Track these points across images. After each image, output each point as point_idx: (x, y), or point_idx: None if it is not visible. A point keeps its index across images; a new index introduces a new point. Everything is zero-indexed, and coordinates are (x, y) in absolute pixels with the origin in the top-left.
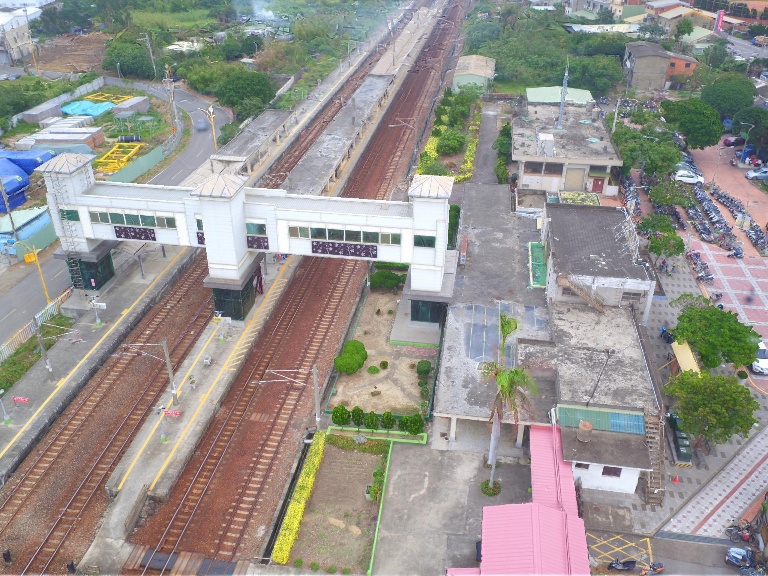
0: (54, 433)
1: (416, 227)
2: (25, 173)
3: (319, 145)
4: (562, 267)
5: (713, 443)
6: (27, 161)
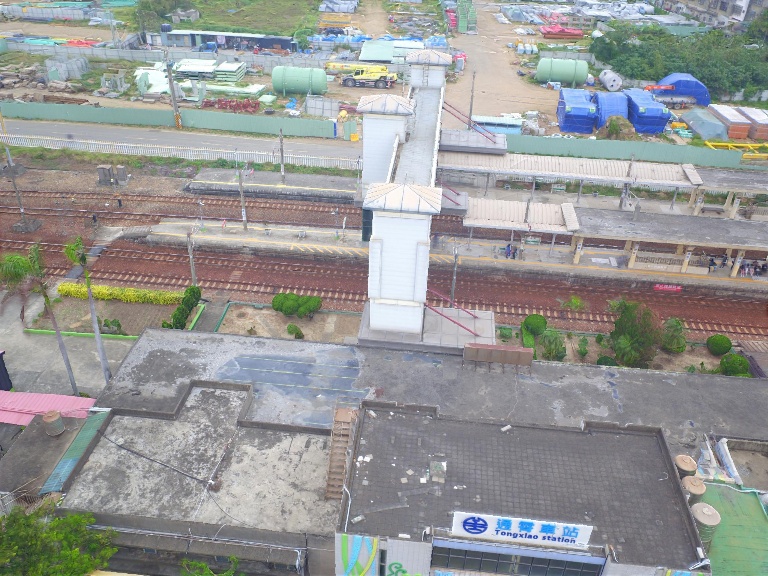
0: (235, 199)
1: None
2: (627, 116)
3: None
4: (400, 422)
5: None
6: (636, 107)
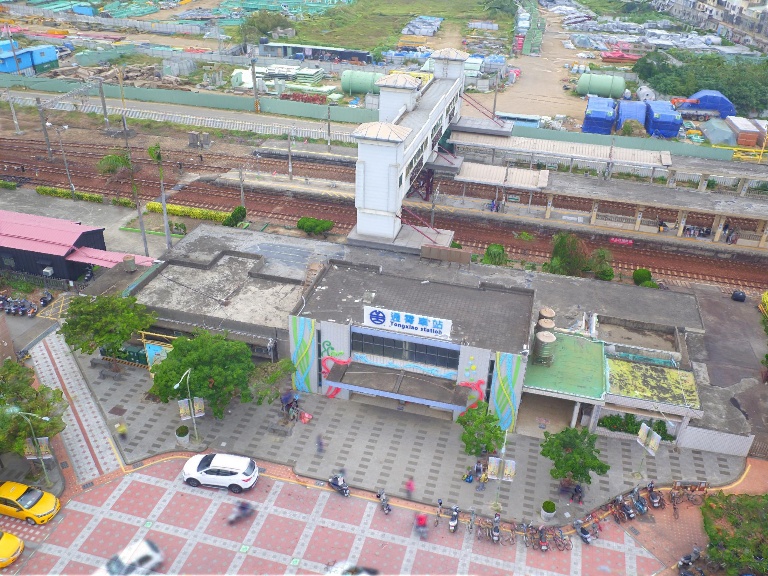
0: None
1: None
2: (644, 121)
3: (756, 201)
4: (353, 273)
5: (114, 381)
6: None
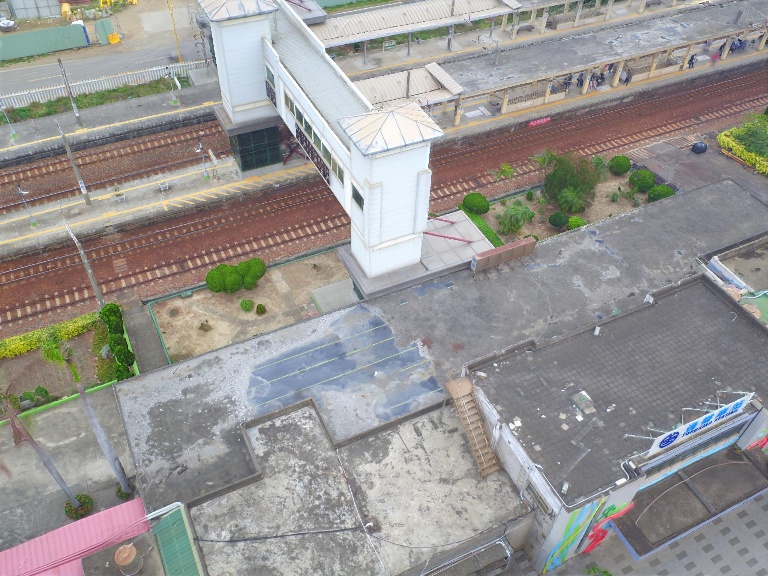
0: (30, 166)
1: (353, 173)
2: None
3: (634, 29)
4: (510, 370)
5: None
6: None
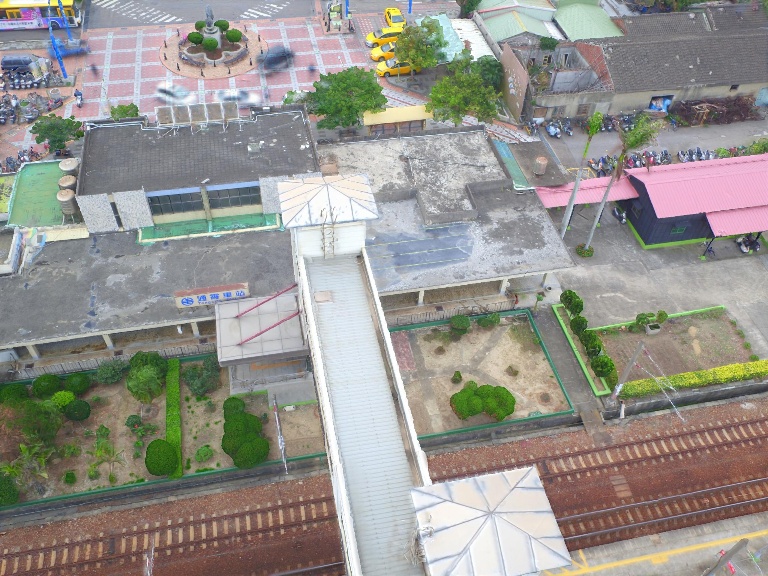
0: None
1: None
2: None
3: None
4: (288, 172)
5: None
6: None
